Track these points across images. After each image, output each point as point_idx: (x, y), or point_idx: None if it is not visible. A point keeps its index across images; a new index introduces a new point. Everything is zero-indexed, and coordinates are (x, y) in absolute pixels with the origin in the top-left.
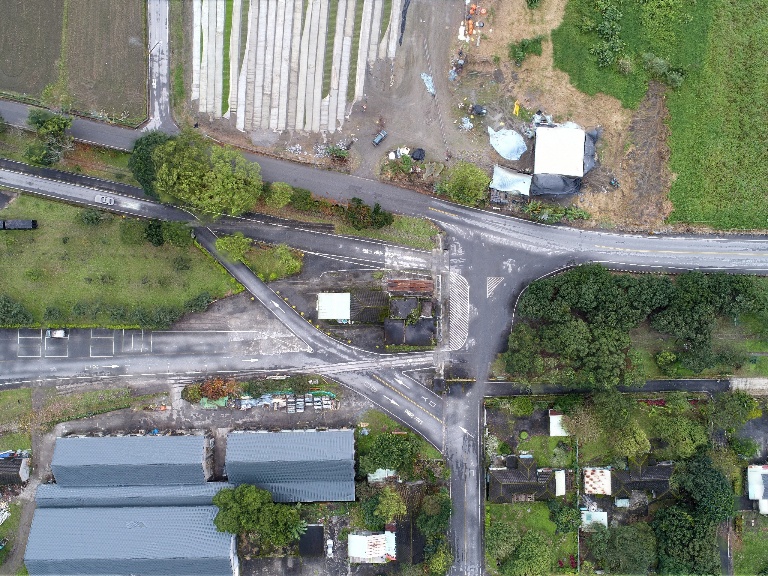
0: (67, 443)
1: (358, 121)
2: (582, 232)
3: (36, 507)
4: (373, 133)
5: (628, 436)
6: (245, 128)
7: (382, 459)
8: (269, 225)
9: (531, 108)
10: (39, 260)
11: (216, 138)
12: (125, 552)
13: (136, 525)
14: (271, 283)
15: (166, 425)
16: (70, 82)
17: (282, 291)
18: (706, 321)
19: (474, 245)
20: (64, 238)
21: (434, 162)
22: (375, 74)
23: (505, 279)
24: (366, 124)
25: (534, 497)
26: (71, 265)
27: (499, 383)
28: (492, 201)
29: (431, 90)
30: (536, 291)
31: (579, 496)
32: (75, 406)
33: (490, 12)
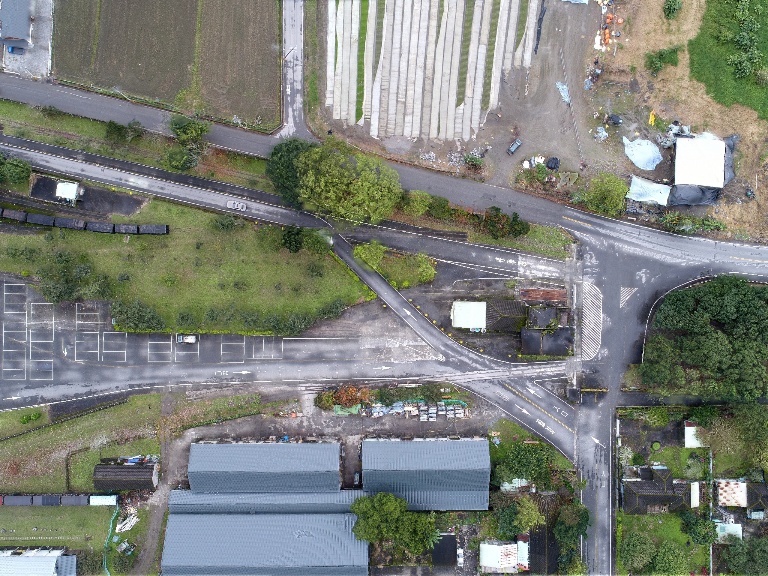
0: (202, 449)
1: (492, 129)
2: (717, 243)
3: (165, 513)
4: (507, 141)
5: (766, 449)
6: (379, 135)
7: (520, 469)
8: (402, 233)
9: (667, 118)
10: (170, 265)
11: (356, 145)
12: (262, 559)
13: (303, 534)
14: (403, 291)
15: (296, 432)
16: (203, 87)
17: (414, 299)
18: None
19: (608, 255)
20: (198, 243)
21: (569, 171)
22: (510, 82)
23: (639, 289)
24: (500, 132)
25: (668, 508)
26: (202, 270)
27: (632, 394)
28: (628, 211)
29: (566, 99)
30: (676, 302)
31: (713, 508)
32: (205, 412)
33: (627, 22)
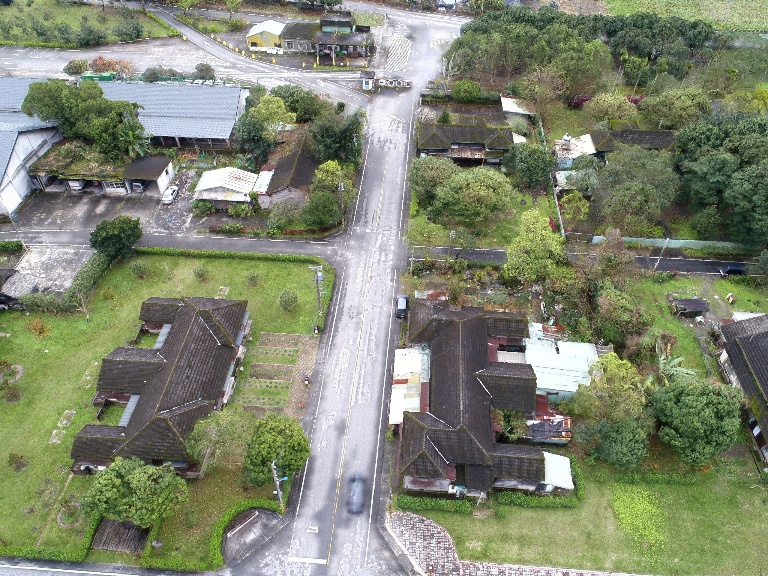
0: None
1: None
2: None
3: None
4: None
5: None
6: None
7: None
8: (224, 12)
9: None
10: None
11: None
12: None
13: None
14: (209, 34)
15: None
16: None
17: None
18: (670, 41)
19: (419, 26)
20: None
21: None
22: None
23: (449, 41)
24: None
25: (484, 154)
26: None
27: None
28: (438, 4)
29: None
30: None
31: None
32: None
33: None
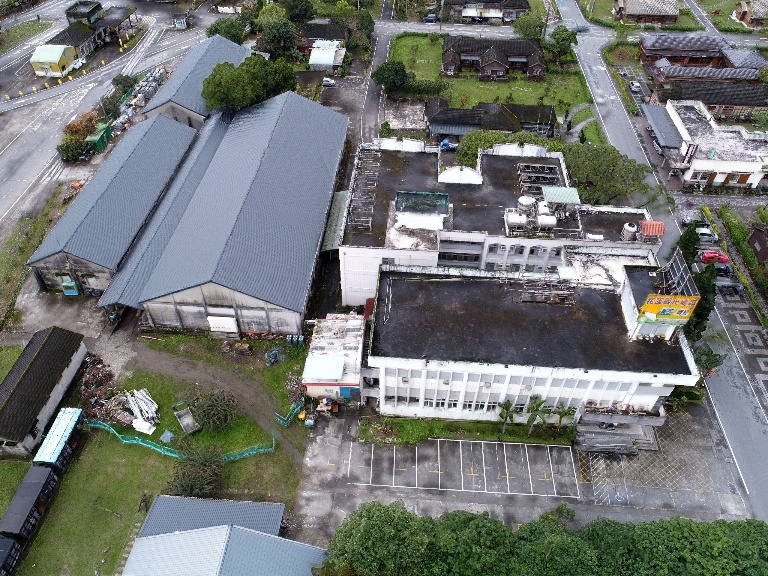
0: (43, 248)
1: None
2: None
3: (151, 348)
4: None
5: None
6: None
7: None
8: None
9: None
10: None
11: None
12: (249, 171)
13: None
14: None
15: None
16: None
17: None
18: None
19: None
20: None
21: None
22: None
23: (110, 1)
24: None
25: None
26: None
27: None
28: None
29: None
30: None
31: None
32: (2, 282)
33: None
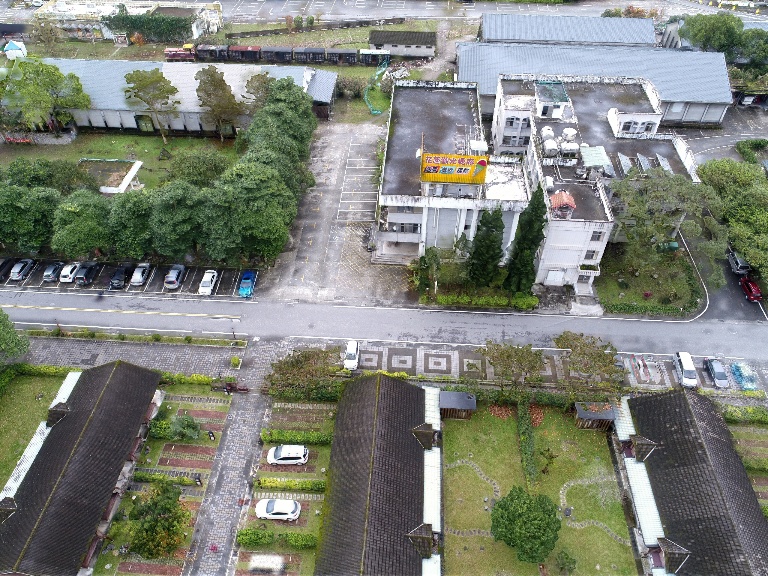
0: None
1: None
2: None
3: None
4: None
5: None
6: None
7: None
8: None
9: None
10: None
11: None
12: None
13: None
14: None
15: None
16: None
17: None
18: None
19: None
20: None
21: None
22: None
23: None
24: None
25: None
26: None
27: None
28: None
29: None
30: None
31: None
32: None
33: None
